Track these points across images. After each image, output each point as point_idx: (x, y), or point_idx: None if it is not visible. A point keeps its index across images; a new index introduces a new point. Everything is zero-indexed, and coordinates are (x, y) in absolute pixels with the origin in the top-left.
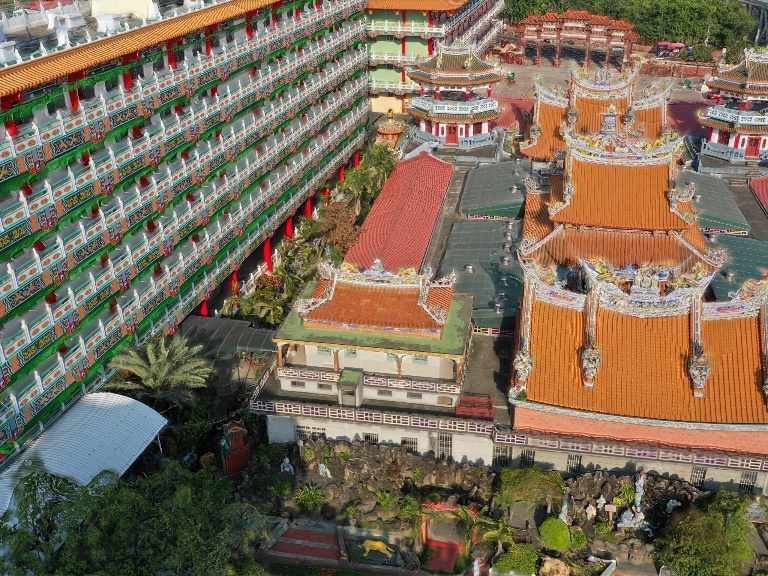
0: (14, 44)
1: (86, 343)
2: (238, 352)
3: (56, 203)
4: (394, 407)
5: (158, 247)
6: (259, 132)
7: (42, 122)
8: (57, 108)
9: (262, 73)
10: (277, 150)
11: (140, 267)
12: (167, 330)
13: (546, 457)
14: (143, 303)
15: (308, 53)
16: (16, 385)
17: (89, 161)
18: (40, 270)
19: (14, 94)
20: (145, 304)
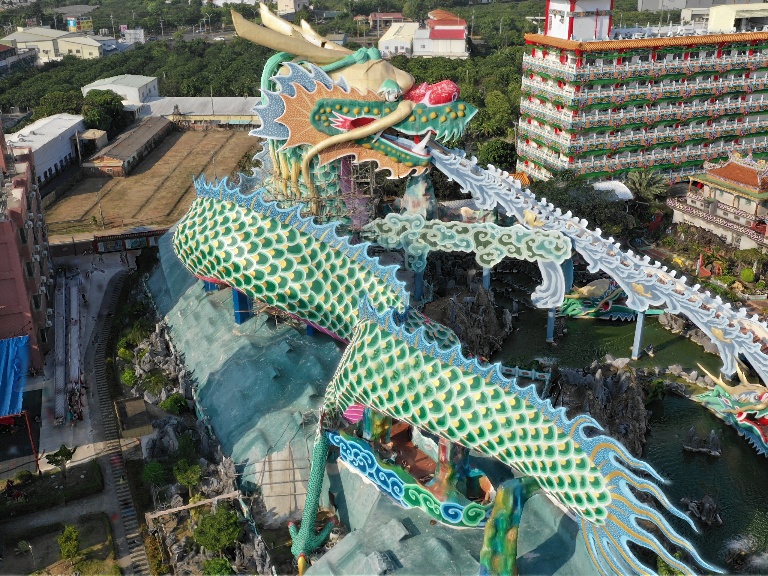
0: None
1: (619, 159)
2: None
3: (626, 95)
4: None
5: (674, 136)
6: None
7: (634, 63)
8: (645, 60)
9: None
10: None
11: (660, 141)
12: (668, 181)
13: None
14: (656, 158)
15: None
16: None
17: (649, 84)
18: (609, 118)
19: (623, 49)
20: (657, 159)
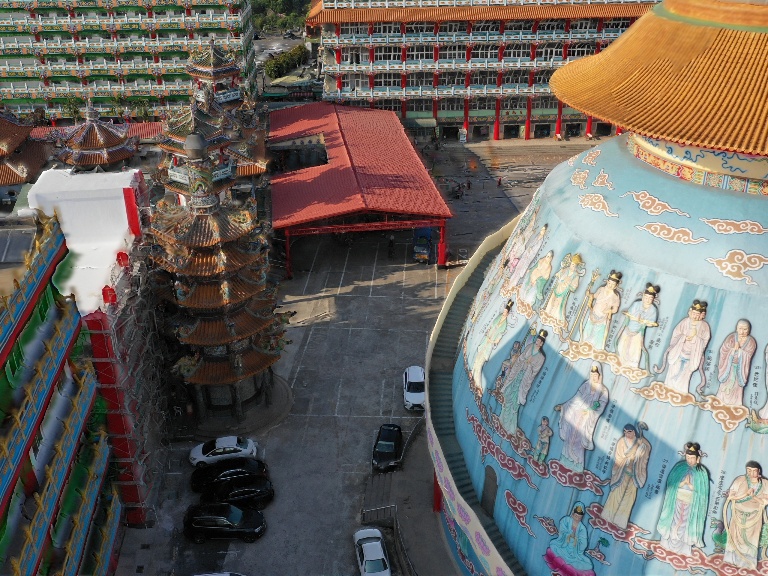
0: None
1: None
2: None
3: None
4: None
5: None
6: (23, 50)
7: None
8: None
9: None
10: (52, 68)
11: None
12: None
13: None
14: None
15: (108, 19)
16: None
17: None
18: None
19: None
20: None
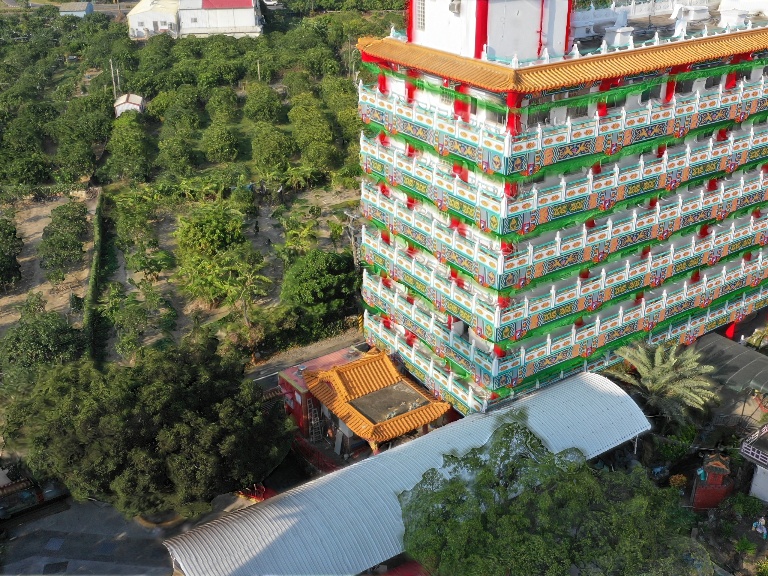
0: (632, 30)
1: (601, 324)
2: (750, 387)
3: (619, 187)
4: None
5: (703, 254)
6: None
7: (632, 108)
8: (651, 97)
9: None
10: None
11: (678, 269)
12: (684, 338)
13: None
14: (669, 305)
15: None
16: (529, 340)
17: (663, 154)
18: (583, 245)
19: (615, 78)
20: (670, 306)
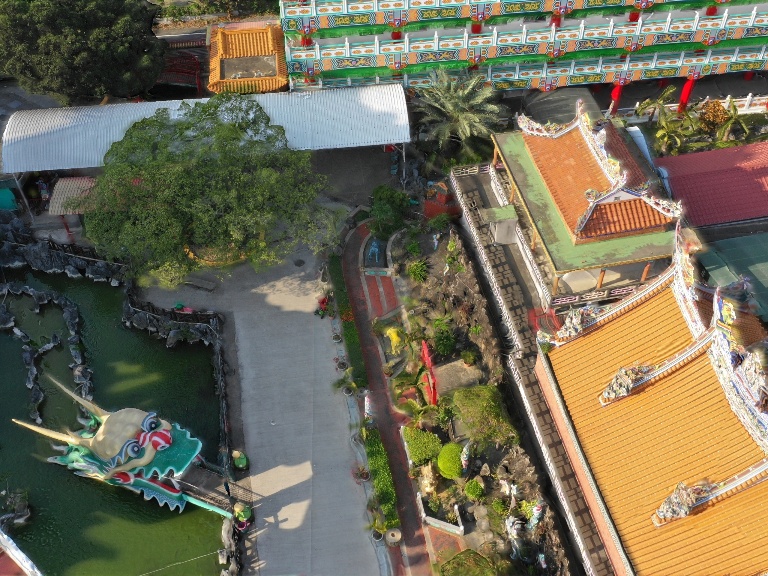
0: None
1: (412, 43)
2: None
3: None
4: (518, 268)
5: (545, 1)
6: None
7: None
8: None
9: None
10: None
11: (509, 9)
12: (538, 84)
13: None
14: (502, 43)
15: None
16: (337, 40)
17: None
18: None
19: None
20: (504, 45)
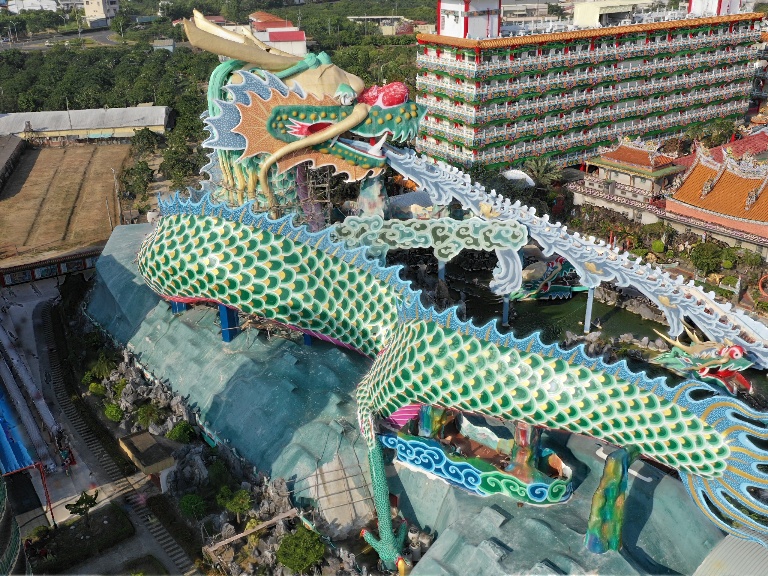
0: None
1: (517, 149)
2: None
3: (520, 89)
4: None
5: (561, 125)
6: (639, 92)
7: None
8: (532, 56)
9: (651, 63)
10: (651, 106)
11: (549, 130)
12: None
13: (676, 227)
14: (547, 146)
15: (692, 59)
16: None
17: (538, 78)
18: (507, 111)
19: (515, 45)
20: (547, 147)
